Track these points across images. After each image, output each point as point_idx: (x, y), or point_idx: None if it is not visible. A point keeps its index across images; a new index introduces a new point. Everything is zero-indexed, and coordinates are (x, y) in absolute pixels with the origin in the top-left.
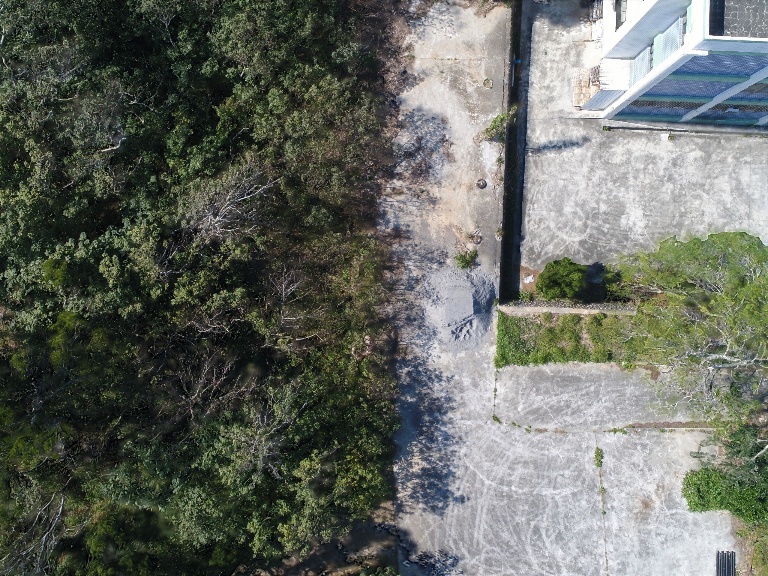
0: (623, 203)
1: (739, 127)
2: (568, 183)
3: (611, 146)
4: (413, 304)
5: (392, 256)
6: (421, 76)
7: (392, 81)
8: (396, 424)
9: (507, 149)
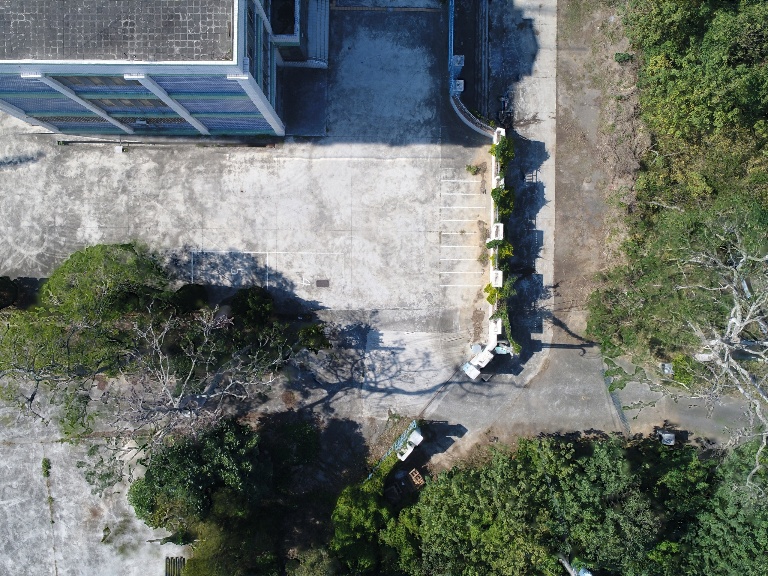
0: (78, 216)
1: (191, 137)
2: (24, 198)
3: (66, 160)
4: None
5: None
6: None
7: None
8: None
9: None
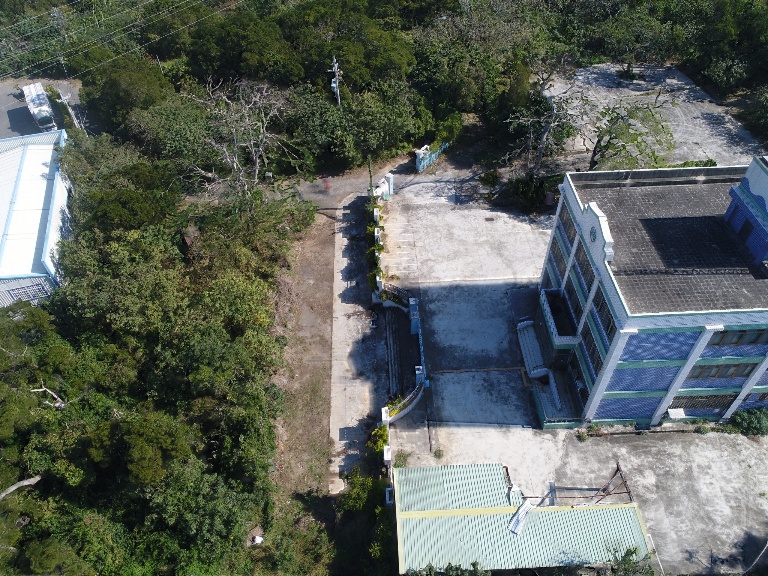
0: None
1: None
2: None
3: None
4: None
5: None
6: None
7: None
8: (764, 122)
9: None
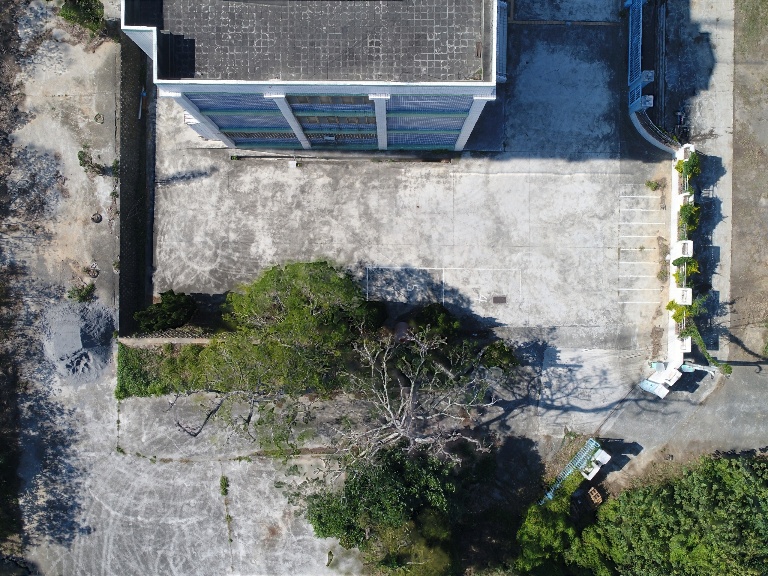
0: (252, 231)
1: (366, 152)
2: (197, 213)
3: (239, 175)
4: (32, 339)
5: (10, 292)
6: (33, 113)
7: (4, 119)
8: None
9: (133, 181)
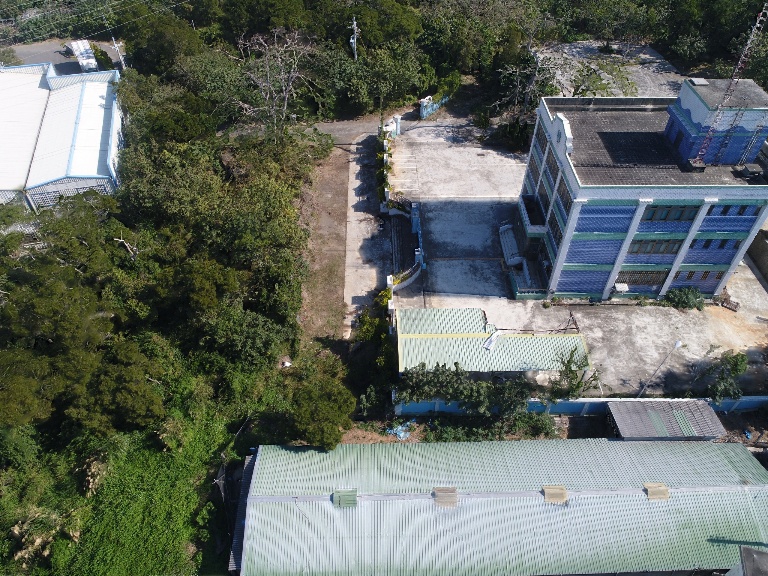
0: None
1: None
2: None
3: None
4: None
5: None
6: None
7: None
8: None
9: None
